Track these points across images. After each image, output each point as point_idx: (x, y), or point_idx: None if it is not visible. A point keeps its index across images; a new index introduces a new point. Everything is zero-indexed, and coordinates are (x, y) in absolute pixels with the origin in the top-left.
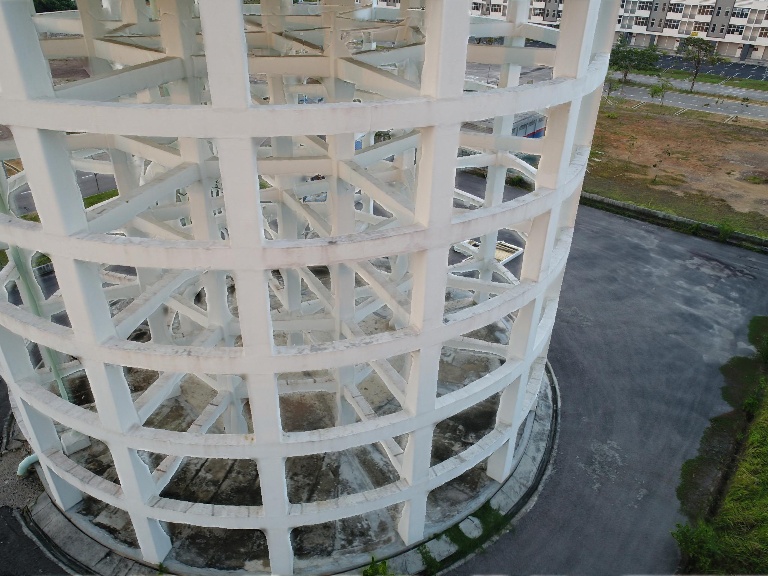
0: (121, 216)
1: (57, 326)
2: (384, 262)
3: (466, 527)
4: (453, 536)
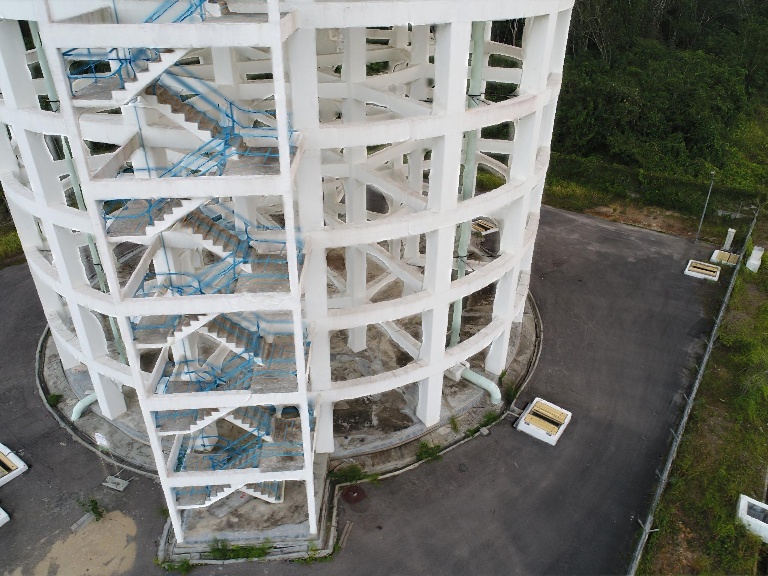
0: None
1: None
2: None
3: None
4: None
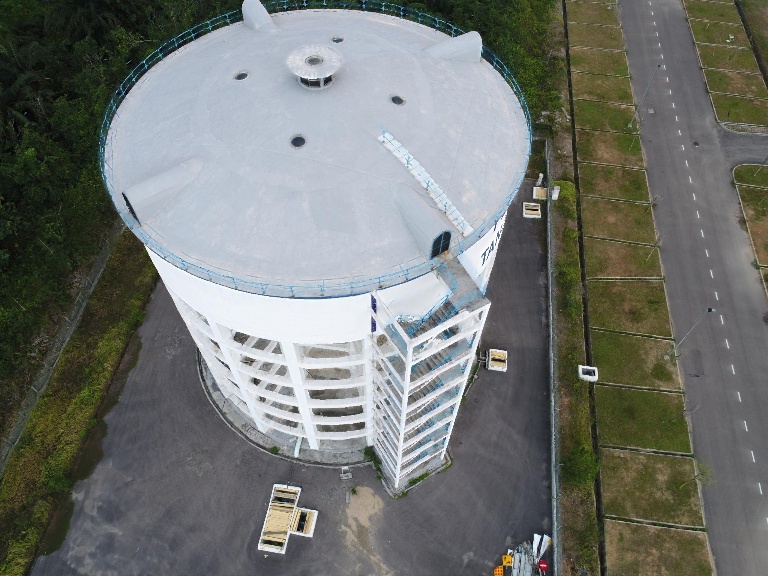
0: None
1: None
2: (354, 442)
3: None
4: None
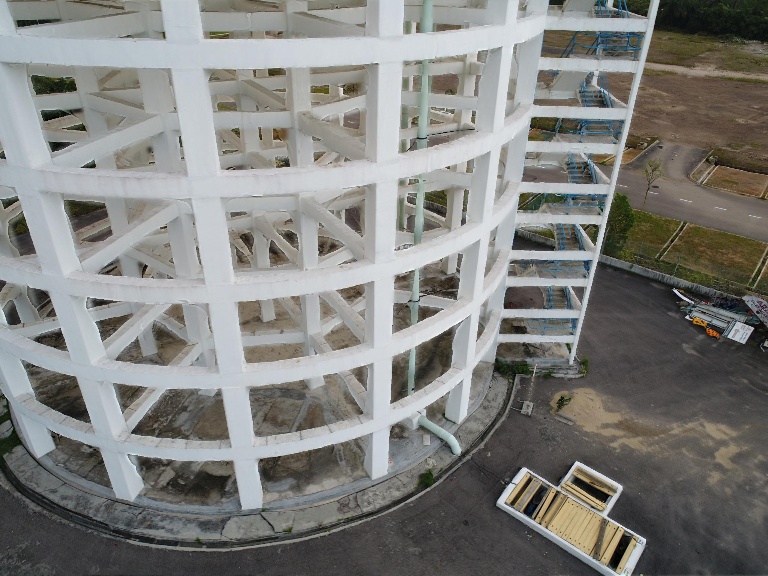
0: (43, 71)
1: (54, 120)
2: (478, 374)
3: (5, 425)
4: (3, 417)
